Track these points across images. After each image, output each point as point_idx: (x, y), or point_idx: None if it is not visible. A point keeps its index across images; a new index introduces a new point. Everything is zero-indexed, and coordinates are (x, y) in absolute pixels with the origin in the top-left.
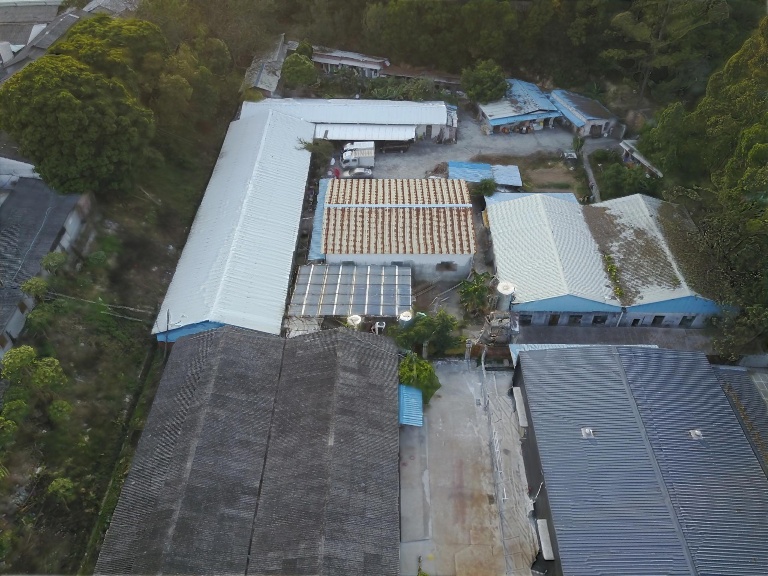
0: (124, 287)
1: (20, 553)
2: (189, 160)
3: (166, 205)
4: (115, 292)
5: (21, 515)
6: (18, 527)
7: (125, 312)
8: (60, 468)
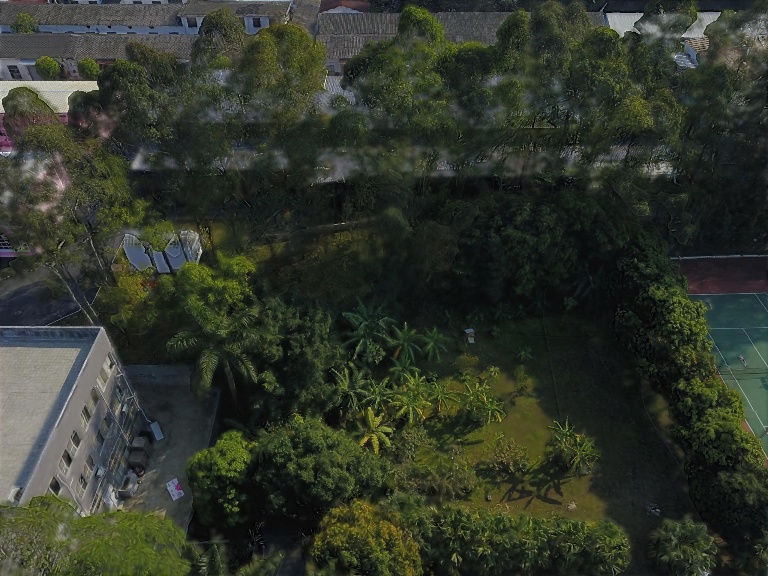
0: (621, 3)
1: (485, 8)
2: (746, 2)
3: (696, 5)
4: (615, 1)
5: (497, 3)
6: (493, 4)
7: (605, 6)
8: (518, 6)
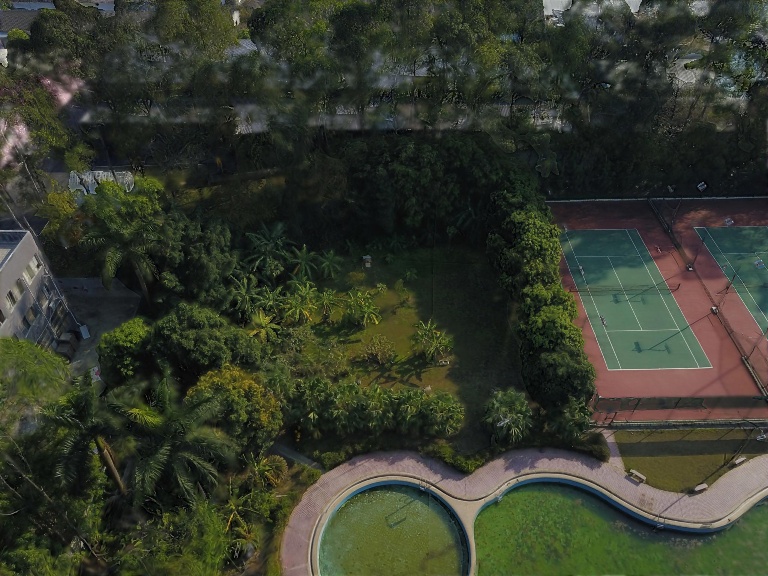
0: None
1: None
2: None
3: None
4: None
5: None
6: None
7: None
8: None
